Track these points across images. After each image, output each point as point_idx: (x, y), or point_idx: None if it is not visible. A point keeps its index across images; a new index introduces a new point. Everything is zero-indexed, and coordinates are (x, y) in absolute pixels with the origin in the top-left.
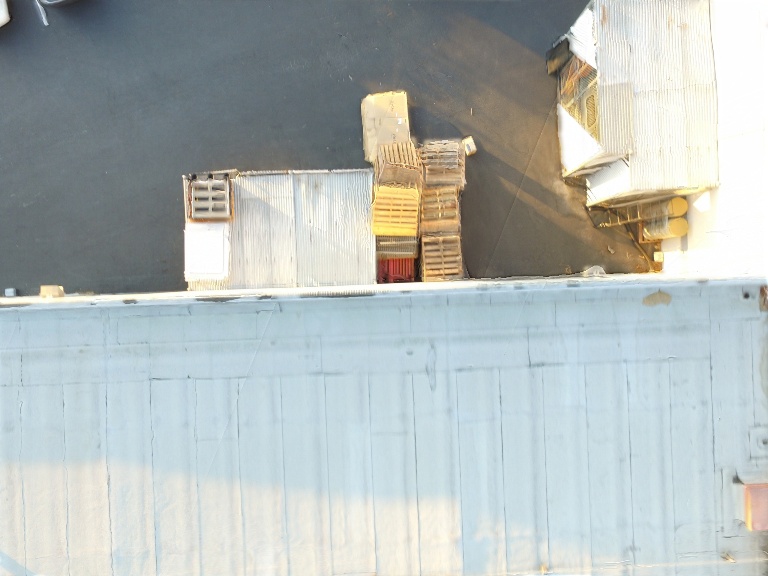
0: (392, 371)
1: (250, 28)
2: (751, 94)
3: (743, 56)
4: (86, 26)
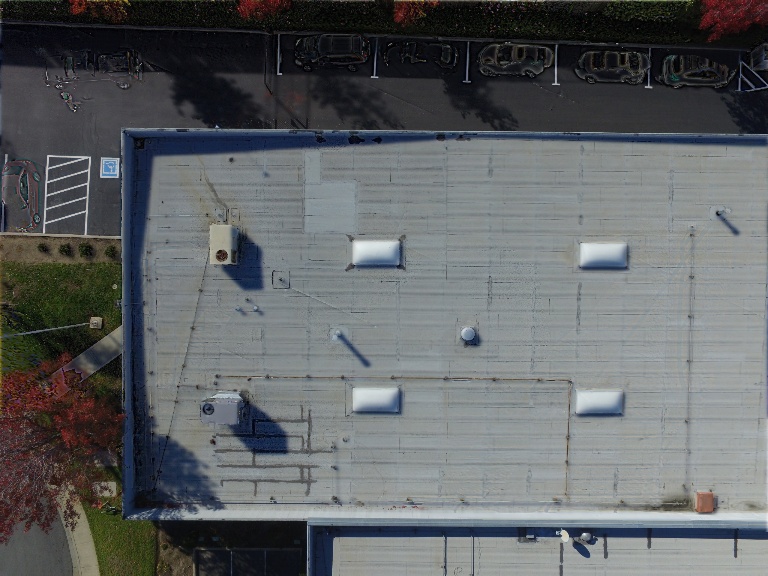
0: (763, 370)
1: None
2: None
3: None
4: None
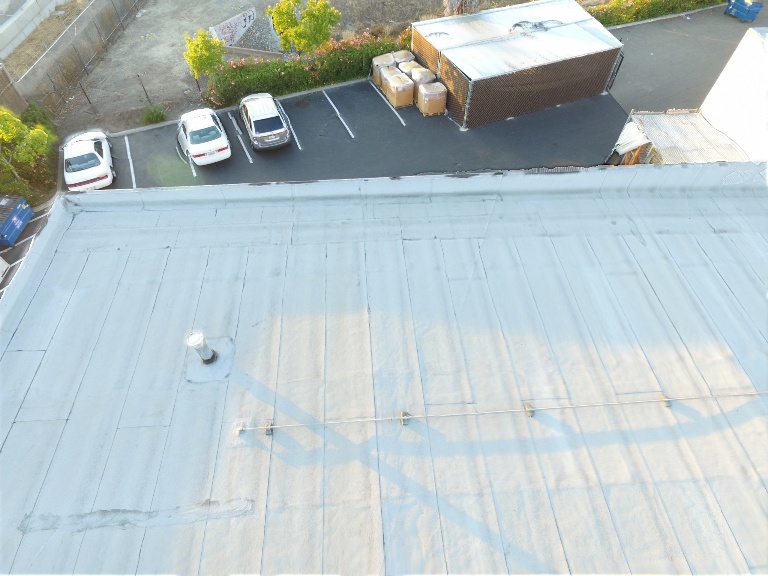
0: (604, 234)
1: (393, 161)
2: (763, 134)
3: (744, 123)
4: (279, 162)
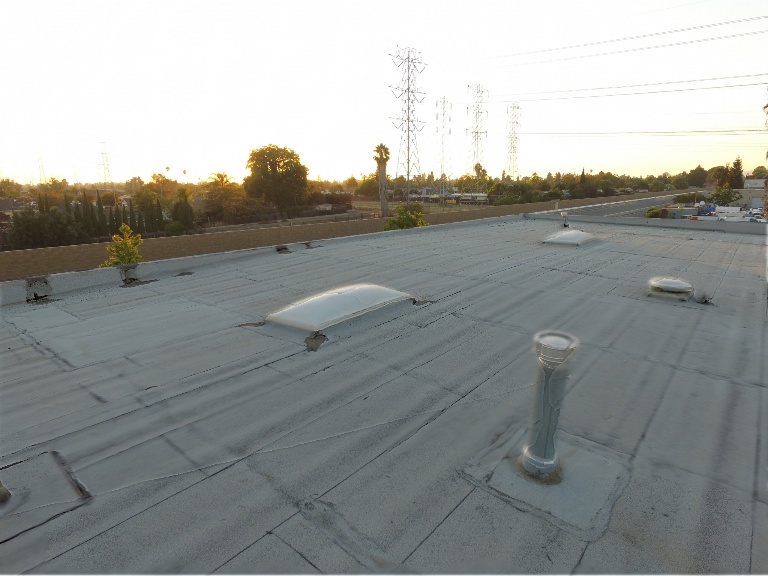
0: None
1: None
2: None
3: None
4: None
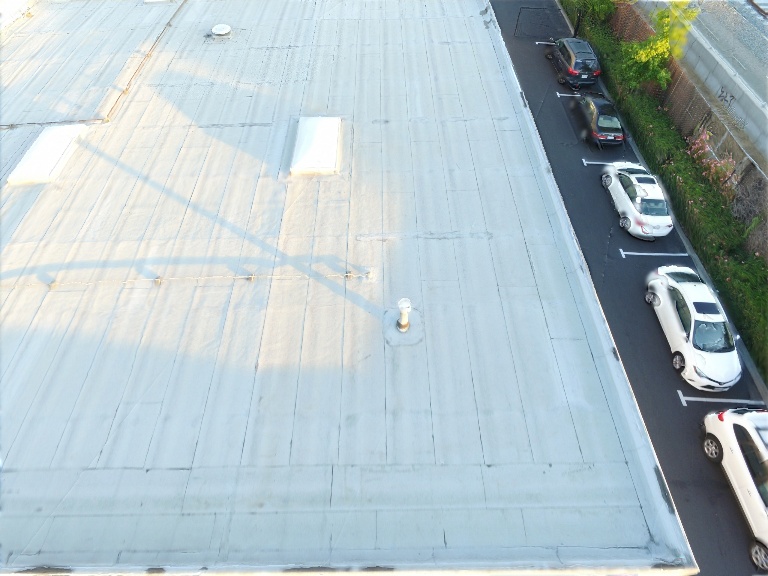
0: None
1: None
2: None
3: None
4: None
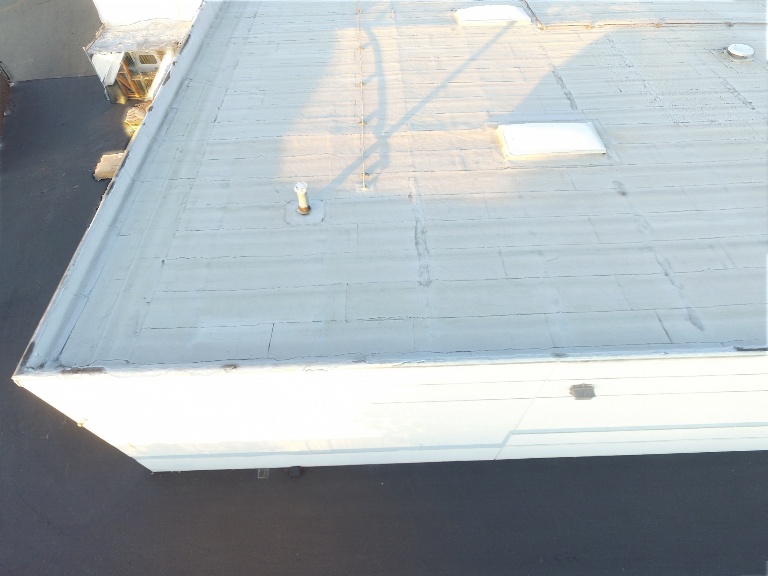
0: None
1: (1, 242)
2: (159, 2)
3: (141, 6)
4: None
